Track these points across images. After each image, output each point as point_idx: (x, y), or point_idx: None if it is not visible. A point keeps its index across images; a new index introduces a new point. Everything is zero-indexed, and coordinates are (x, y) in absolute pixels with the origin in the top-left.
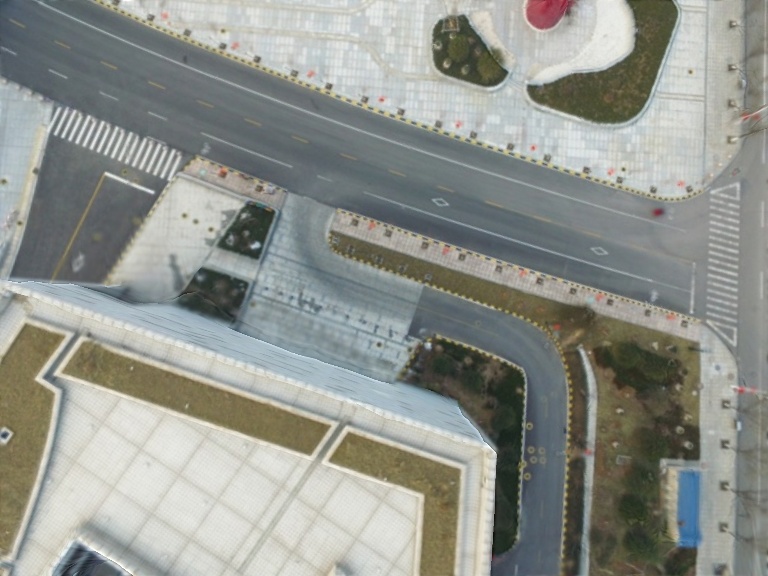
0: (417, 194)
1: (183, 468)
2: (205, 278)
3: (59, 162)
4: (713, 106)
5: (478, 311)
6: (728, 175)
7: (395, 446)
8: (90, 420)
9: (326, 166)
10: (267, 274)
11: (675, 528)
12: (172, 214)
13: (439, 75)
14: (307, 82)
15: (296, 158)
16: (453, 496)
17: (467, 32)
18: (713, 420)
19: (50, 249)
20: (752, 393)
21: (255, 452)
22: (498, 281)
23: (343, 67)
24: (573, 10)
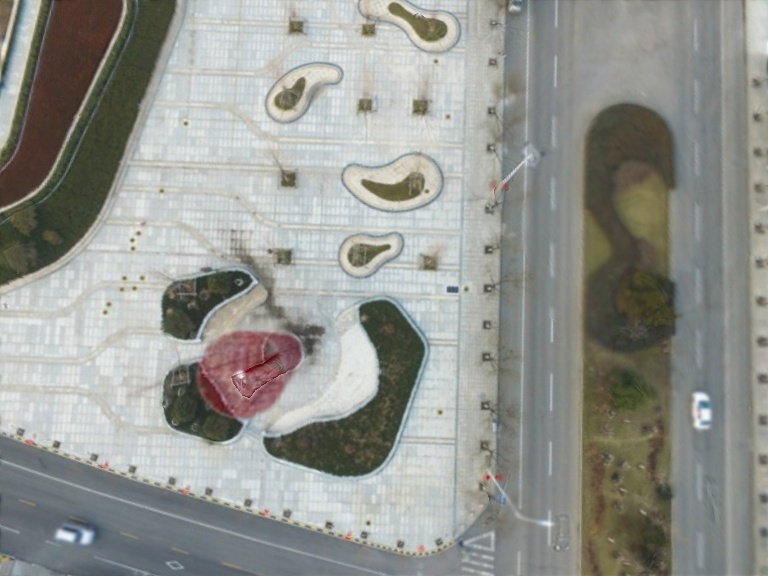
0: (150, 557)
1: None
2: None
3: None
4: (464, 449)
5: None
6: (481, 525)
7: None
8: None
9: (55, 530)
10: None
11: None
12: None
13: (171, 430)
14: (34, 441)
15: (23, 523)
16: None
17: (199, 383)
18: None
19: None
20: None
21: None
22: None
23: (72, 423)
24: (315, 349)
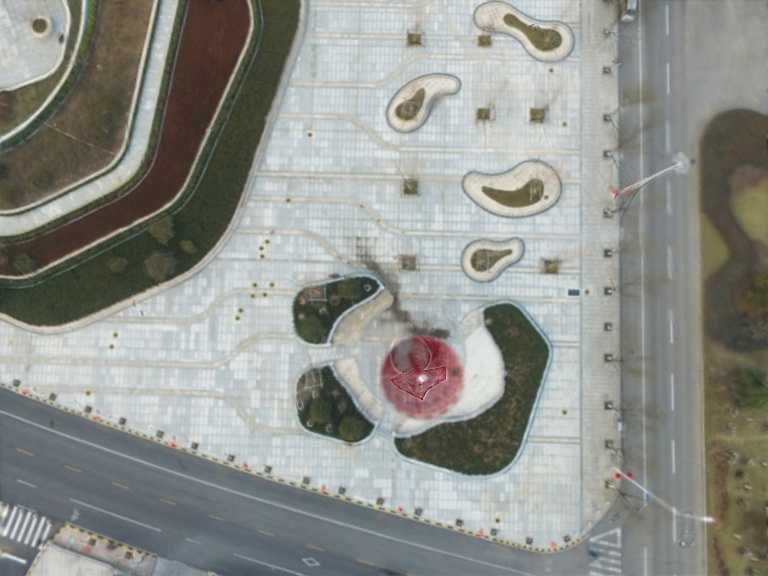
0: (287, 554)
1: None
2: None
3: None
4: (589, 448)
5: None
6: (607, 521)
7: None
8: None
9: (195, 528)
10: None
11: None
12: None
13: (304, 431)
14: (173, 443)
15: (164, 521)
16: None
17: (331, 386)
18: None
19: None
20: None
21: None
22: None
23: (208, 425)
24: (441, 351)
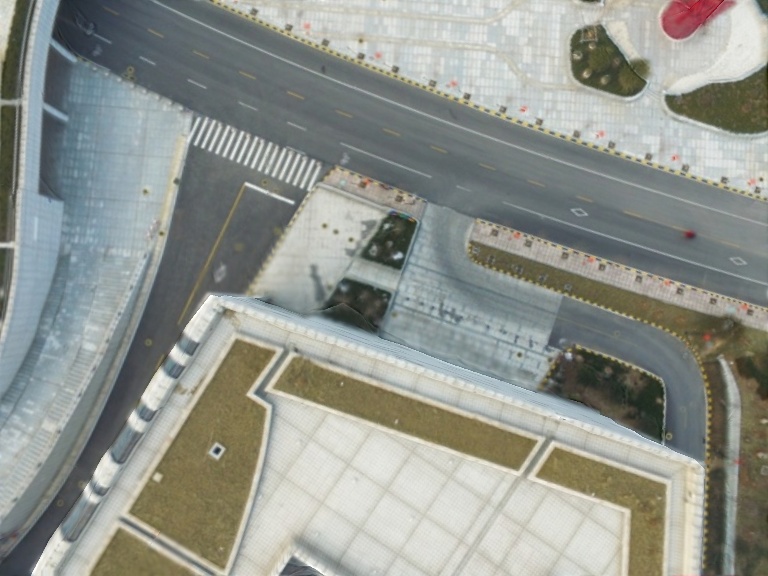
0: (556, 204)
1: (390, 483)
2: (349, 289)
3: (199, 172)
4: None
5: (617, 321)
6: None
7: (601, 461)
8: (298, 435)
9: (465, 176)
10: (408, 284)
11: None
12: (312, 224)
13: (577, 85)
14: (445, 92)
15: (435, 168)
16: (660, 511)
17: (605, 42)
18: None
19: (192, 259)
20: None
21: (461, 467)
22: (638, 291)
23: (481, 77)
24: (708, 20)
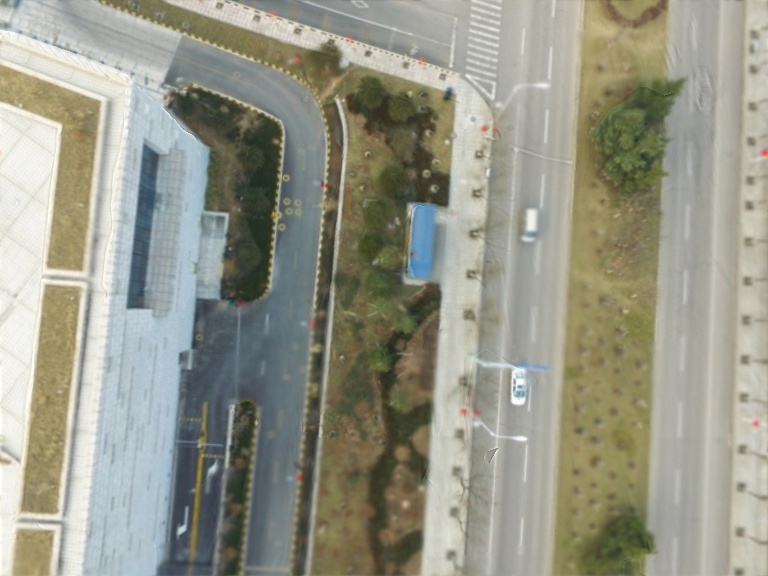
0: None
1: None
2: None
3: None
4: None
5: (237, 62)
6: None
7: (34, 75)
8: None
9: None
10: (21, 18)
11: (409, 260)
12: None
13: None
14: None
15: None
16: (90, 125)
17: None
18: (465, 168)
19: None
20: (507, 145)
21: None
22: (255, 30)
23: None
24: None
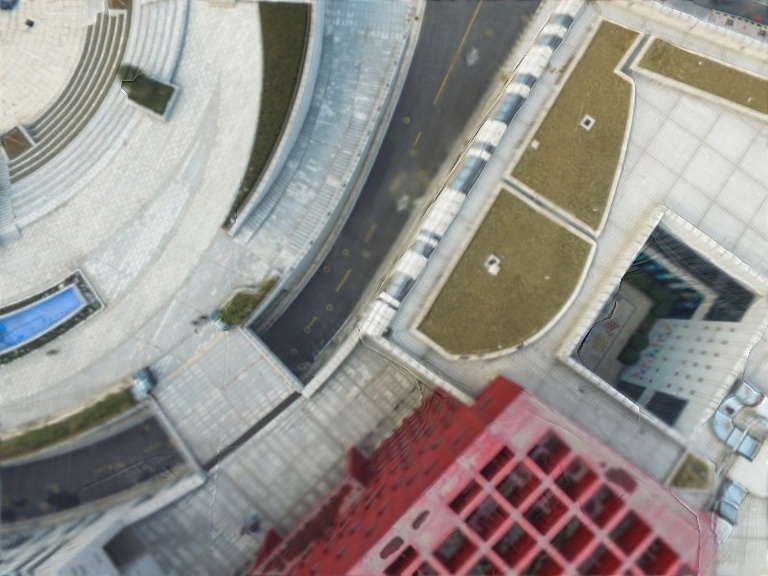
0: None
1: (740, 160)
2: None
3: None
4: None
5: None
6: None
7: None
8: (656, 114)
9: None
10: None
11: None
12: None
13: None
14: None
15: None
16: None
17: None
18: None
19: (445, 43)
20: None
21: None
22: None
23: None
24: None
